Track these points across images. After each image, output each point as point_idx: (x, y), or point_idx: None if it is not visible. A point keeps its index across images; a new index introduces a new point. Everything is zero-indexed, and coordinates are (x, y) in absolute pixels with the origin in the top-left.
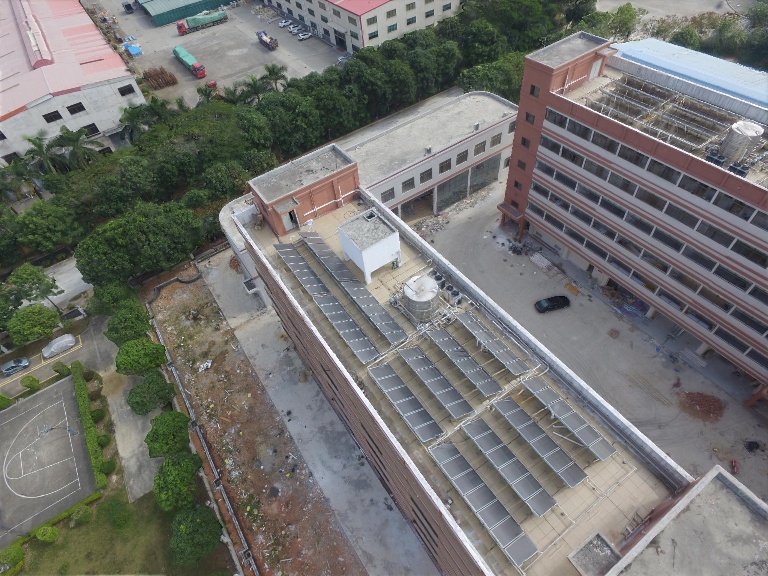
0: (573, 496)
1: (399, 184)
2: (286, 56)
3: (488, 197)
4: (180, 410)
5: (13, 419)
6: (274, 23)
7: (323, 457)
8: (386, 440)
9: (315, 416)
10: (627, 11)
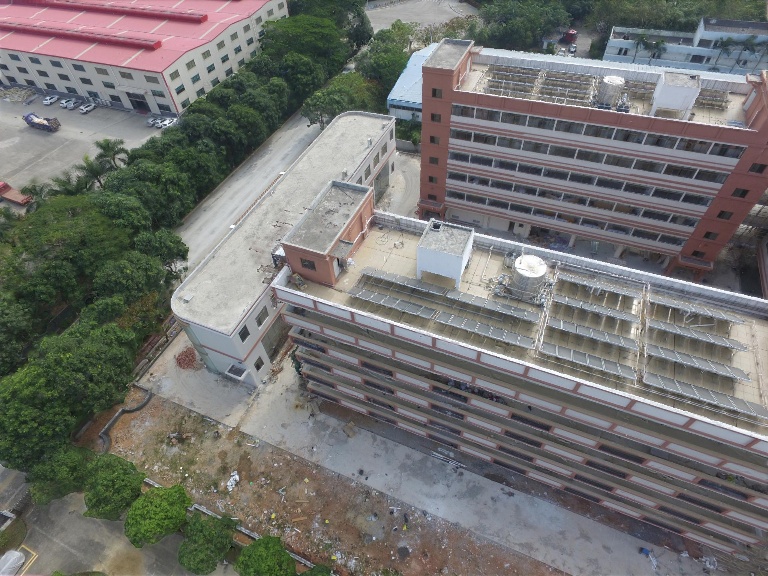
0: (741, 359)
1: None
2: (78, 133)
3: (392, 202)
4: (240, 542)
5: None
6: (34, 103)
7: (424, 490)
8: (594, 400)
9: (388, 460)
10: (402, 26)
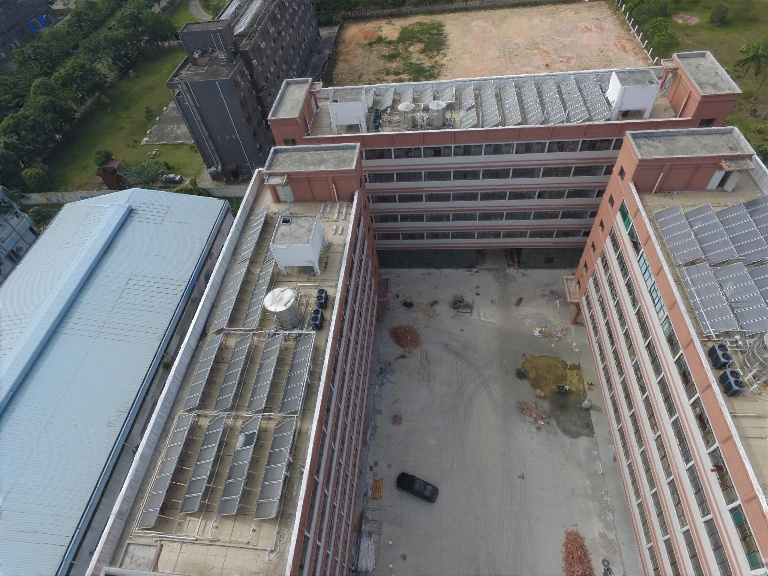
0: None
1: None
2: None
3: None
4: None
5: None
6: None
7: None
8: None
9: None
10: None
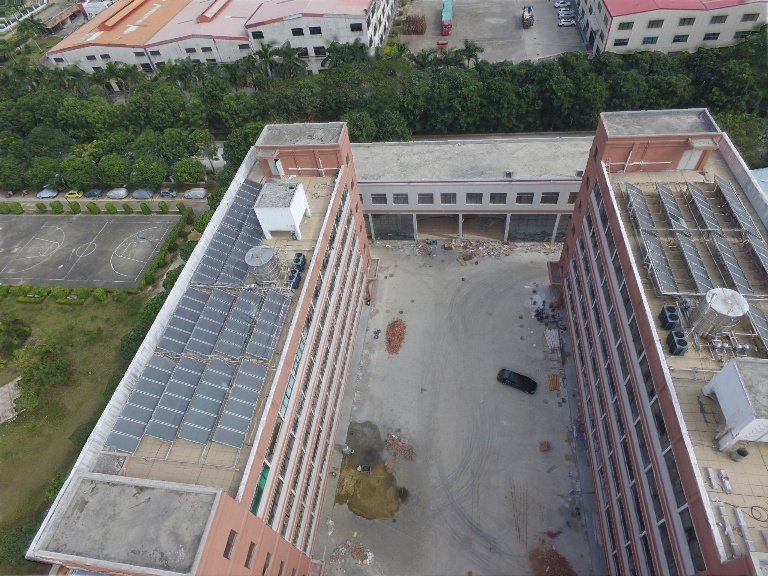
0: (188, 448)
1: (463, 193)
2: (532, 38)
3: None
4: None
5: (143, 223)
6: (554, 1)
7: None
8: None
9: None
10: None
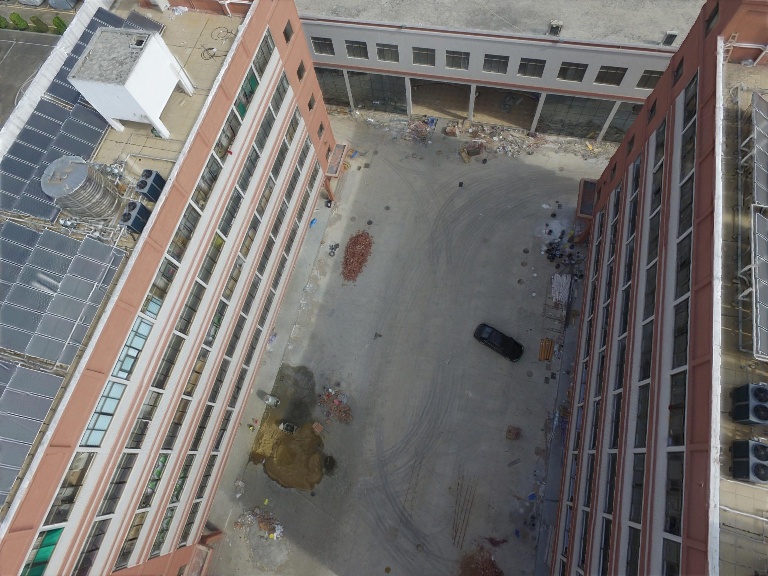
0: None
1: (480, 53)
2: None
3: None
4: None
5: None
6: None
7: None
8: None
9: None
10: None
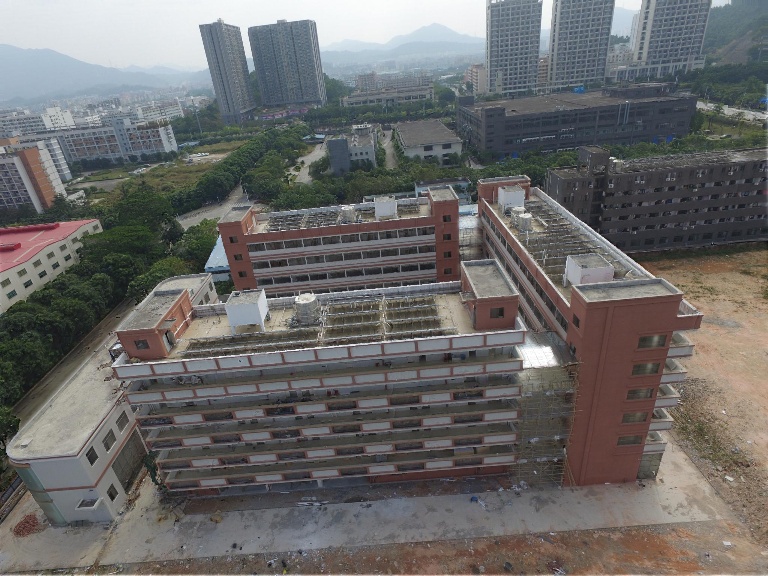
0: (442, 313)
1: None
2: None
3: None
4: None
5: None
6: None
7: (295, 535)
8: (363, 358)
9: (258, 526)
10: (208, 221)
